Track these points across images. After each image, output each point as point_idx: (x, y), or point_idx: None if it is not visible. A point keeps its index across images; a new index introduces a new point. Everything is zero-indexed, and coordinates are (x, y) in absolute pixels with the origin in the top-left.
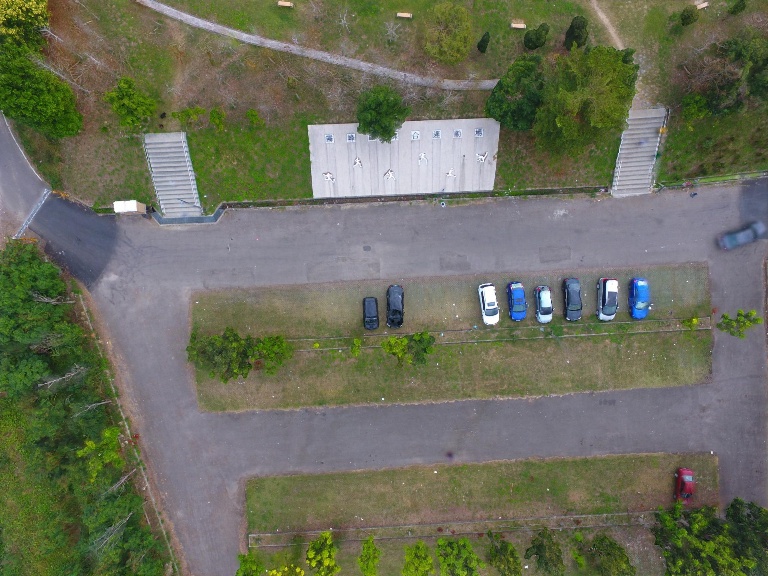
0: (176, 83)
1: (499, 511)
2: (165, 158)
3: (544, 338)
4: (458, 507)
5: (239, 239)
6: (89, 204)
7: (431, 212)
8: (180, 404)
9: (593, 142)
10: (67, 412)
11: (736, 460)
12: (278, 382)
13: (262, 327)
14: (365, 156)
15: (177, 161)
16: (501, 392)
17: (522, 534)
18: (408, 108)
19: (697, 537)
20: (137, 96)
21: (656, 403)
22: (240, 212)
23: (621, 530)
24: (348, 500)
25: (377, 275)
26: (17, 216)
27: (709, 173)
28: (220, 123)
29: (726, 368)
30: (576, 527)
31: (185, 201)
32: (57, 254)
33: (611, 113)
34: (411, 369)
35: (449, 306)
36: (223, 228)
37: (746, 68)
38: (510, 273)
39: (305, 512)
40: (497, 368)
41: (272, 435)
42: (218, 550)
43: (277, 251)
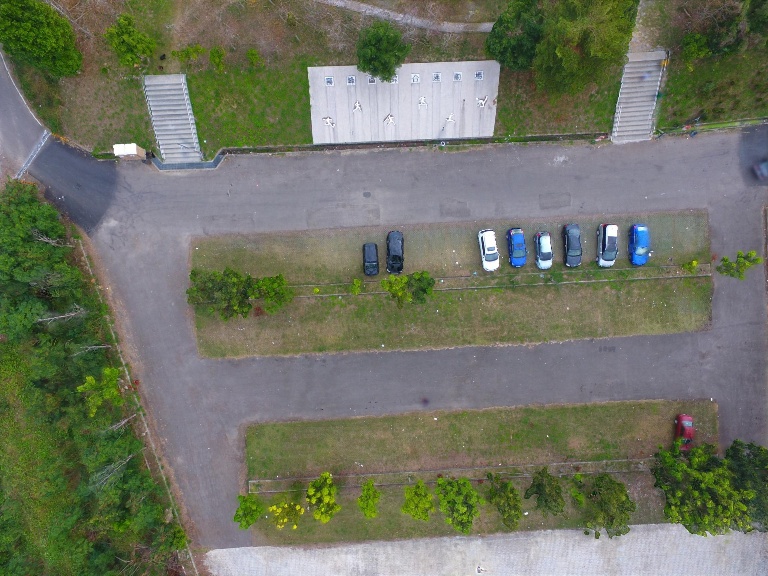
0: (176, 25)
1: (499, 458)
2: (165, 101)
3: (544, 285)
4: (458, 454)
5: (239, 185)
6: (89, 149)
7: (431, 158)
8: (180, 350)
9: (593, 79)
10: (67, 354)
11: (736, 407)
12: (278, 328)
13: (262, 273)
14: (365, 100)
15: (177, 104)
16: (501, 339)
17: (522, 481)
18: (408, 45)
19: (697, 470)
20: (137, 33)
21: (656, 350)
22: (240, 158)
23: (621, 477)
24: (348, 446)
25: (377, 221)
26: (17, 161)
27: (709, 119)
28: (220, 63)
29: (726, 315)
30: (576, 474)
31: (185, 146)
32: (57, 199)
33: (611, 41)
34: (411, 316)
35: (449, 253)
36: (223, 174)
37: (746, 2)
38: (510, 220)
39: (305, 458)
40: (497, 315)
41: (272, 381)
42: (218, 496)
43: (277, 197)
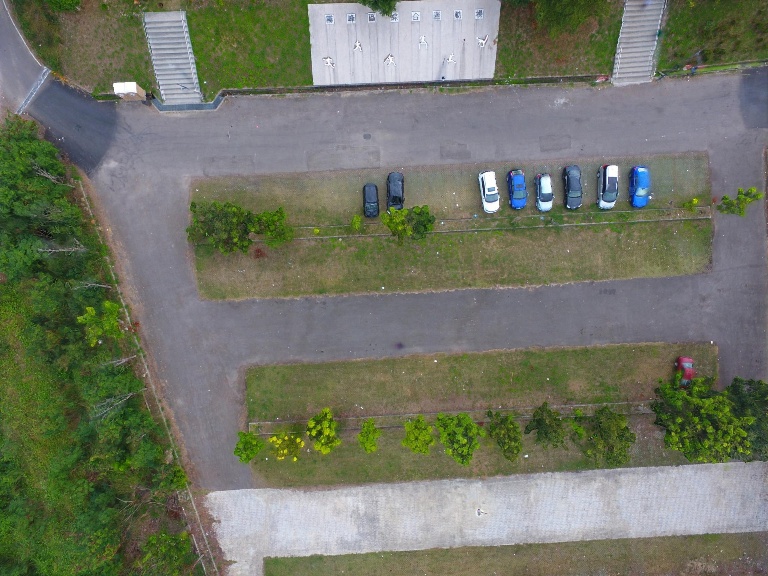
0: None
1: (499, 400)
2: (165, 39)
3: (544, 227)
4: (458, 396)
5: (239, 126)
6: (89, 90)
7: (431, 100)
8: (180, 292)
9: (594, 12)
10: (67, 291)
11: (736, 350)
12: (278, 270)
13: None
14: (365, 39)
15: (177, 42)
16: (501, 281)
17: (522, 423)
18: None
19: None
20: None
21: (656, 293)
22: (240, 99)
23: None
24: (348, 389)
25: (377, 163)
26: (17, 102)
27: (710, 61)
28: None
29: (726, 258)
30: (576, 416)
31: (185, 86)
32: (57, 140)
33: None
34: (411, 258)
35: (449, 195)
36: (223, 115)
37: None
38: (510, 162)
39: (305, 401)
40: (497, 257)
41: (272, 323)
42: (218, 438)
43: (277, 139)
